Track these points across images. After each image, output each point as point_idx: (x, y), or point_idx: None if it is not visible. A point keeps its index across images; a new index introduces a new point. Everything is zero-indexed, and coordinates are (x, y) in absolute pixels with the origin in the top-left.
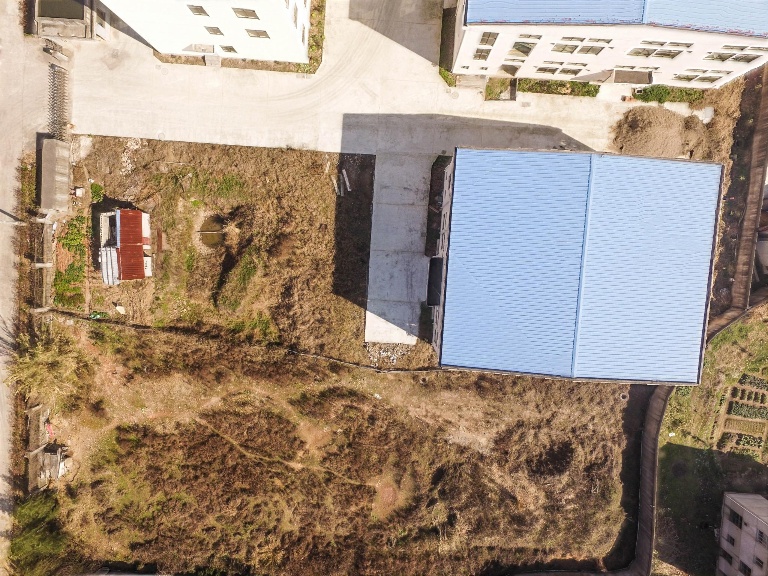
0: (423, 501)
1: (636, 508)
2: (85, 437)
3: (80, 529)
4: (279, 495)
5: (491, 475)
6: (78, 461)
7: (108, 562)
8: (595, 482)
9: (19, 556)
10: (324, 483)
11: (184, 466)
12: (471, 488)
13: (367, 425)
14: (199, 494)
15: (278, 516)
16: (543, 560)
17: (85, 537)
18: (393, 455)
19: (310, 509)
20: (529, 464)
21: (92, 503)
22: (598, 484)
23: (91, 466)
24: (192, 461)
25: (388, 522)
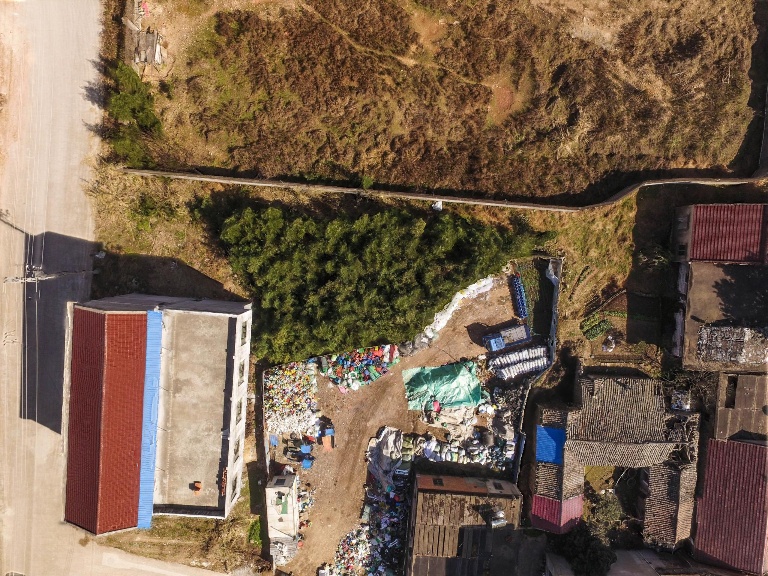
0: (543, 100)
1: (762, 113)
2: (181, 25)
3: (175, 131)
4: (390, 95)
5: (615, 71)
6: (173, 54)
7: (205, 166)
8: (725, 73)
9: (110, 153)
10: (438, 82)
11: (289, 59)
12: (595, 83)
13: (486, 16)
14: (304, 91)
15: (389, 117)
16: (666, 166)
17: (180, 140)
18: (511, 52)
19: (423, 109)
20: (656, 57)
21: (188, 102)
22: (729, 73)
23: (187, 60)
24: (299, 50)
25: (504, 127)
